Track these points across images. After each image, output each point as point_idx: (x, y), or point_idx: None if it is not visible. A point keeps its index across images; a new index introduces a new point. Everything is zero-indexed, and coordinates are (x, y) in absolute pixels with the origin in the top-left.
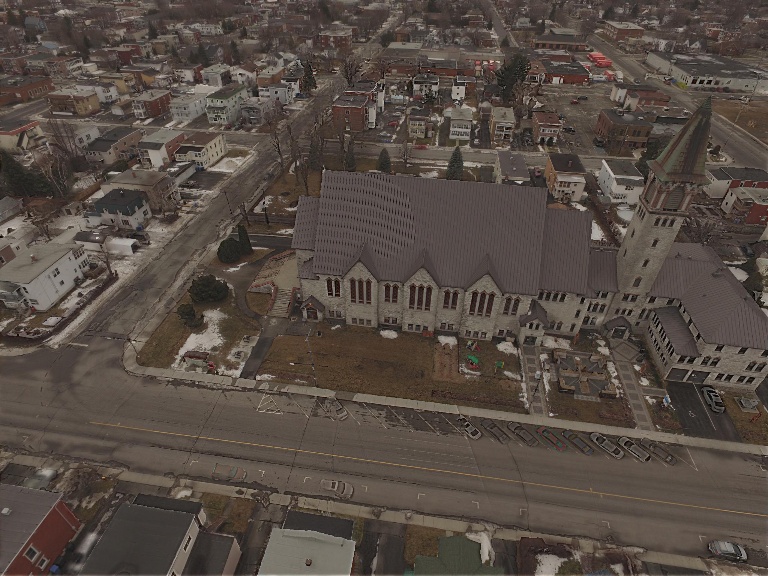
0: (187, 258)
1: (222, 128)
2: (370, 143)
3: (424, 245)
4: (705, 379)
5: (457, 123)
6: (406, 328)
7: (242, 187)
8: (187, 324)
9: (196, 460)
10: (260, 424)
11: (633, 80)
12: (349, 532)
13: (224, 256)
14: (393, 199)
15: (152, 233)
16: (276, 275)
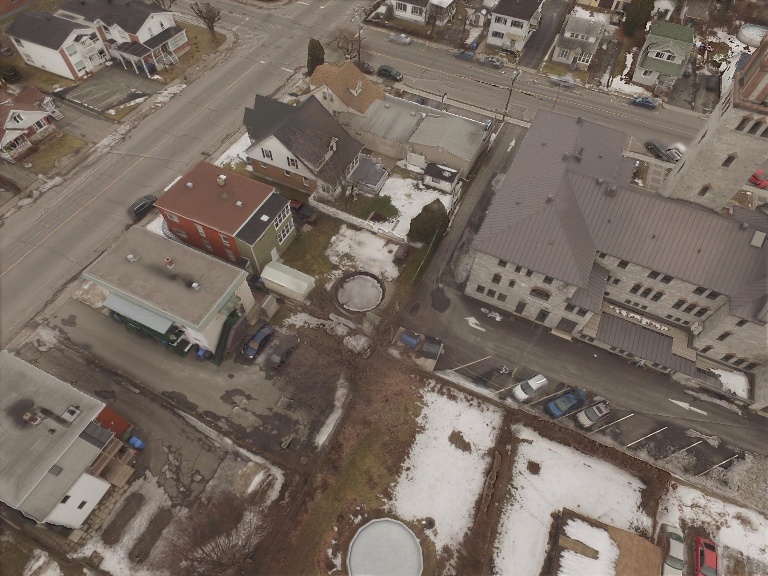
0: None
1: None
2: None
3: None
4: None
5: None
6: None
7: None
8: None
9: None
10: None
11: None
12: None
13: None
14: None
15: None
16: None
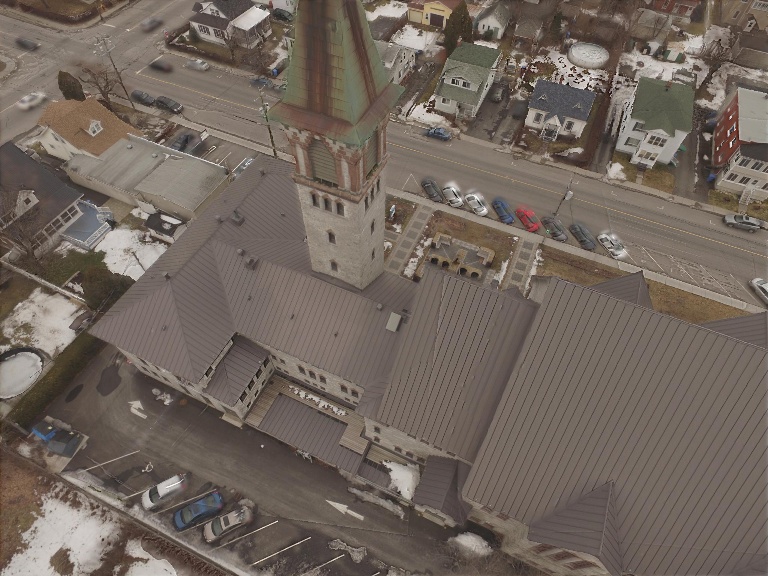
0: None
1: None
2: None
3: None
4: None
5: None
6: None
7: None
8: None
9: None
10: None
11: None
12: (743, 150)
13: None
14: None
15: None
16: None
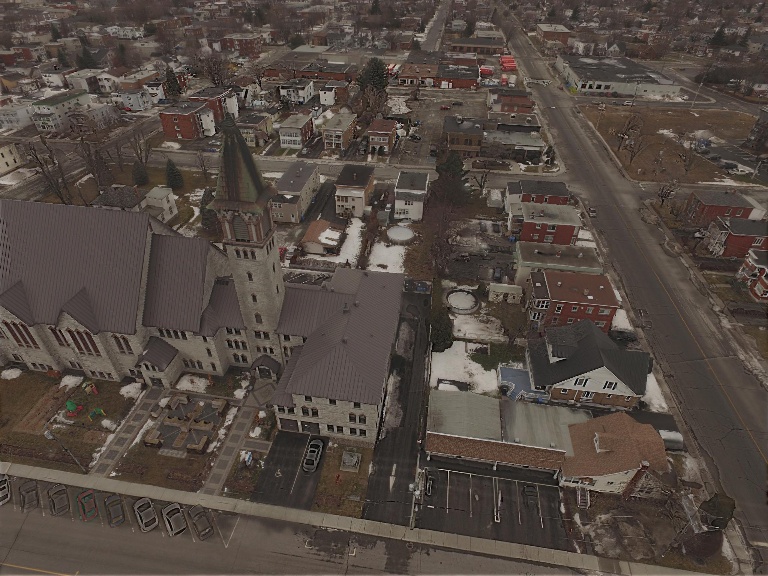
0: None
1: (48, 136)
2: (193, 152)
3: (19, 277)
4: (319, 430)
5: (285, 131)
6: (32, 367)
7: None
8: None
9: None
10: None
11: (526, 84)
12: None
13: None
14: None
15: None
16: None
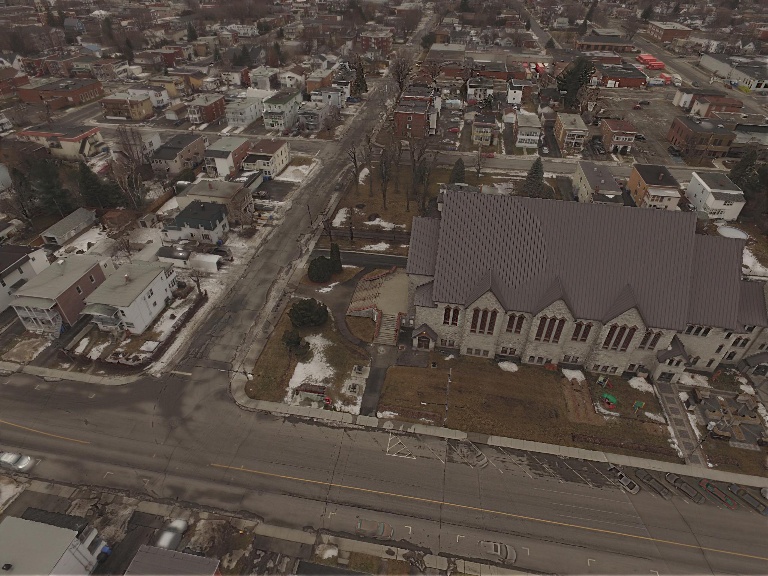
0: (274, 276)
1: (279, 134)
2: (434, 151)
3: (557, 273)
4: None
5: (525, 130)
6: (526, 360)
7: (314, 198)
8: (291, 352)
9: (334, 512)
10: (394, 470)
11: (691, 83)
12: None
13: (316, 275)
14: (522, 223)
15: (233, 248)
16: (376, 298)
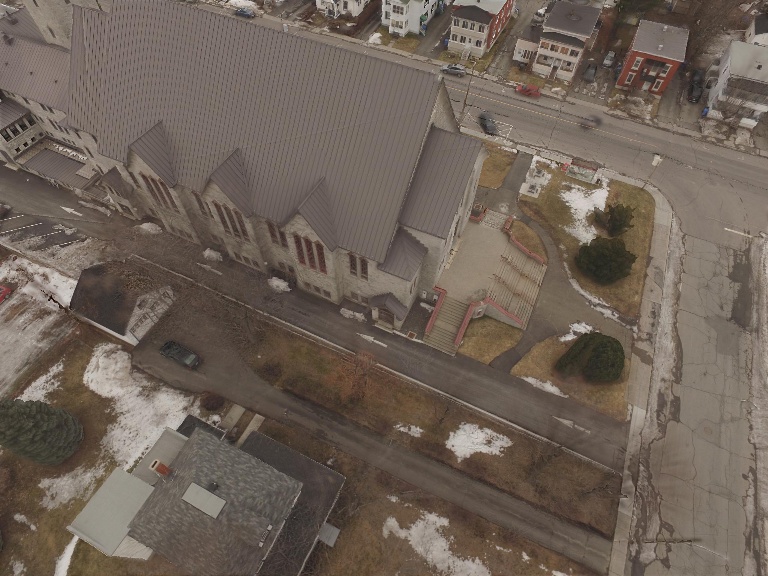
0: (684, 391)
1: None
2: None
3: None
4: None
5: None
6: None
7: None
8: None
9: (555, 106)
10: None
11: None
12: None
13: None
14: None
15: None
16: None
